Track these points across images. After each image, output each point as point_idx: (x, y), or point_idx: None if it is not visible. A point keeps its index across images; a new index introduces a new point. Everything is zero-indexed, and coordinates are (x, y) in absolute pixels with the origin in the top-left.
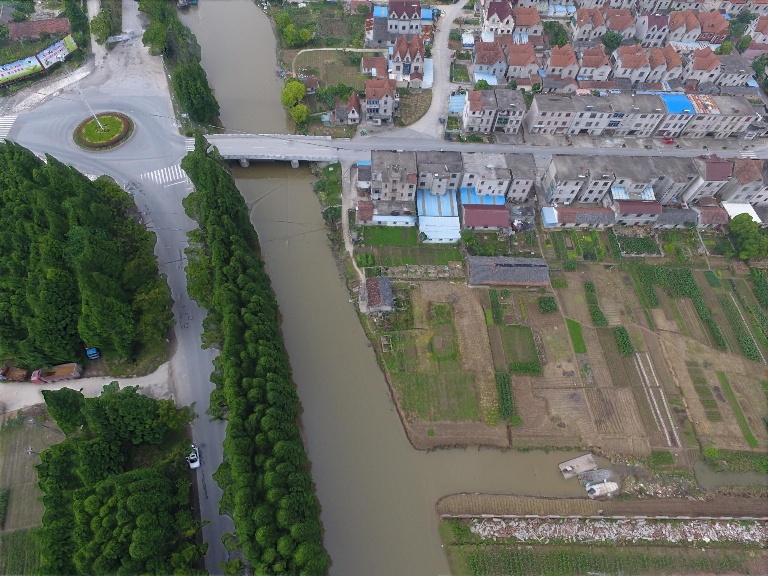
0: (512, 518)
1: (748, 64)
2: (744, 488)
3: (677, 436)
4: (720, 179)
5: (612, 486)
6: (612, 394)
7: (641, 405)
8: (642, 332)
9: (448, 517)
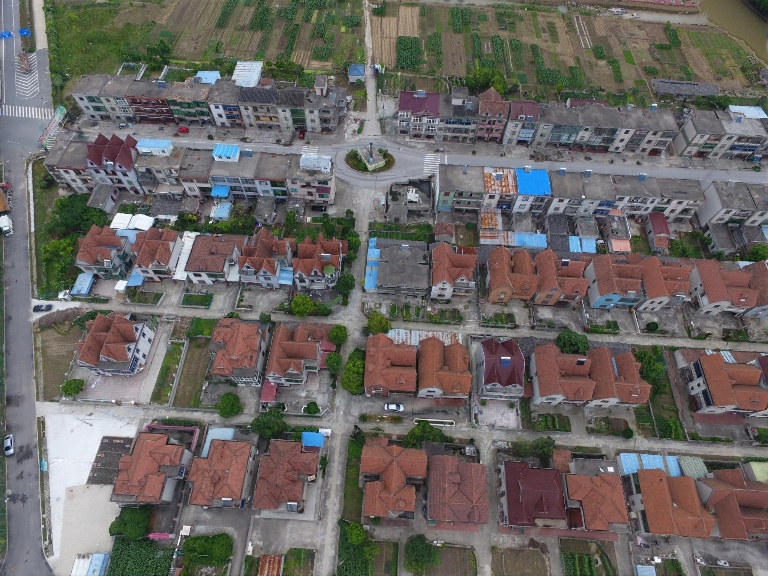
0: (664, 4)
1: (381, 265)
2: (546, 3)
3: (575, 19)
4: (521, 100)
5: (612, 10)
6: (609, 34)
7: (593, 30)
8: (584, 57)
9: (695, 5)
